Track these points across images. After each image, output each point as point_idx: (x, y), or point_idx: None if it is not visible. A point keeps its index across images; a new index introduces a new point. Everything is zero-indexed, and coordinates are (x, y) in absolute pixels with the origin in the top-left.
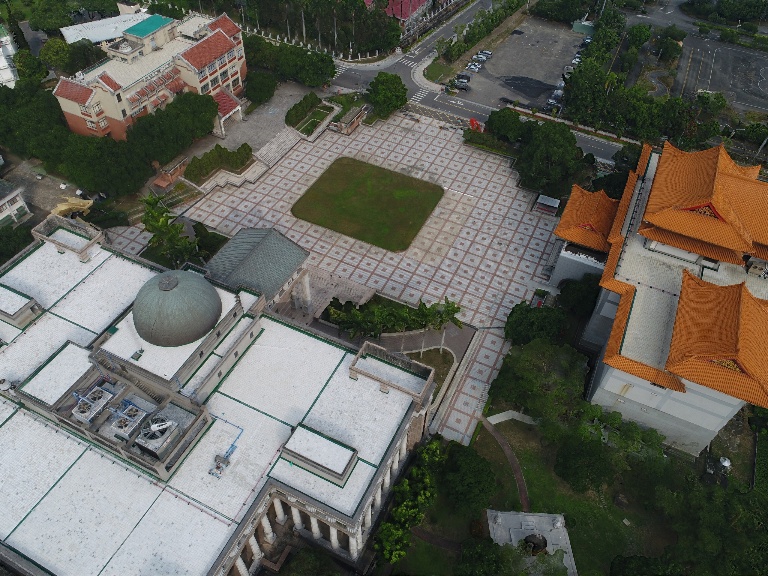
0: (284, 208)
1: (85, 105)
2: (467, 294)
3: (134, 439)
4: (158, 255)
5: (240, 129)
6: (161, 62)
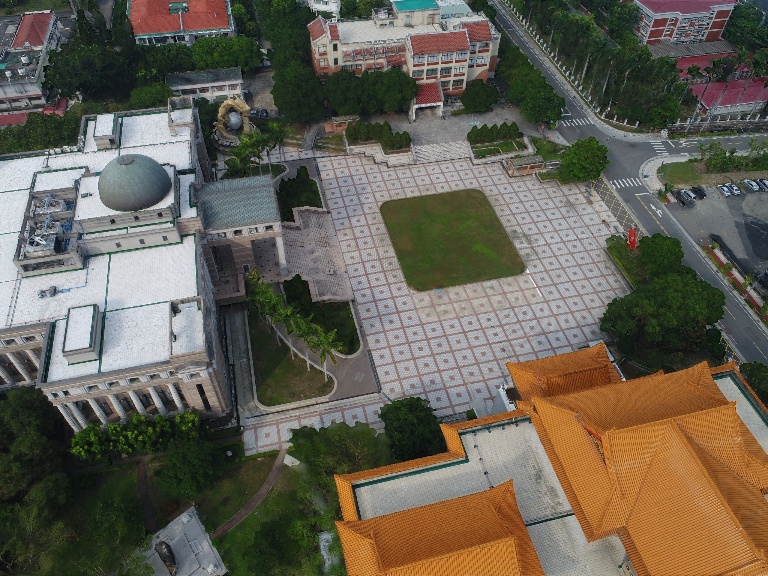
0: (382, 198)
1: (313, 42)
2: (413, 361)
3: None
4: (267, 173)
5: (431, 123)
6: (398, 36)
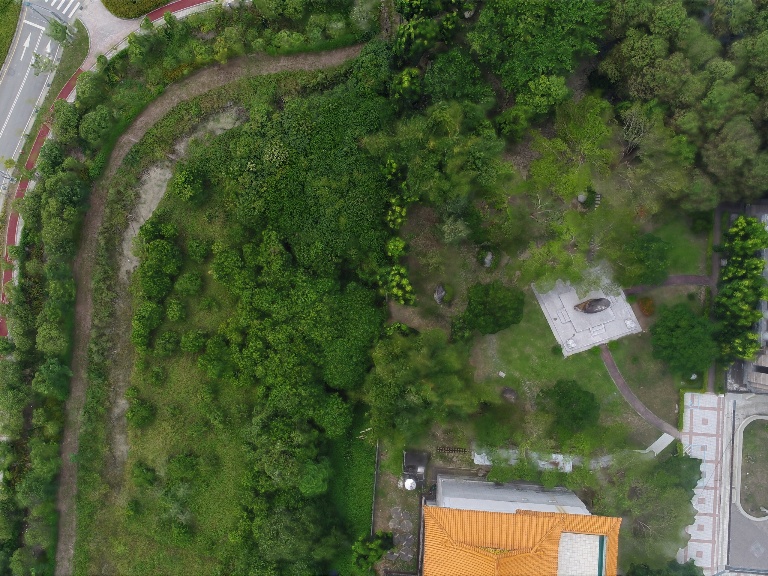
0: None
1: None
2: None
3: None
4: None
5: None
6: None
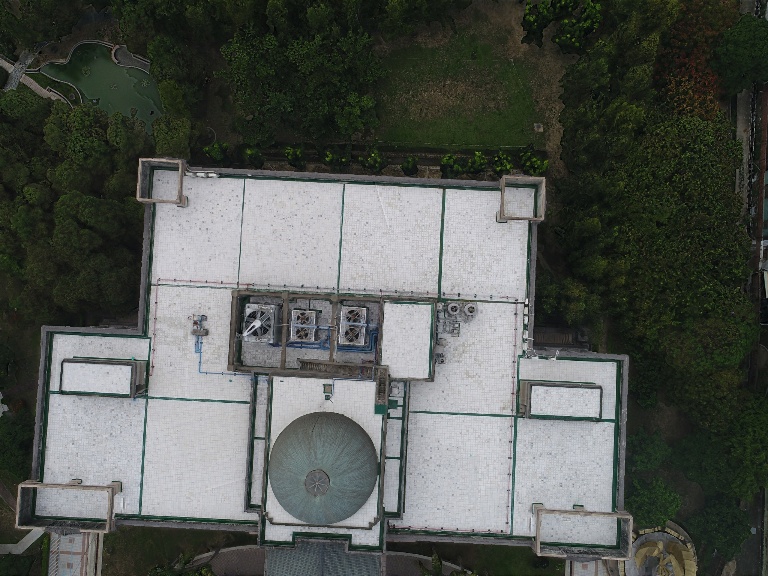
0: None
1: None
2: None
3: (284, 310)
4: None
5: None
6: None
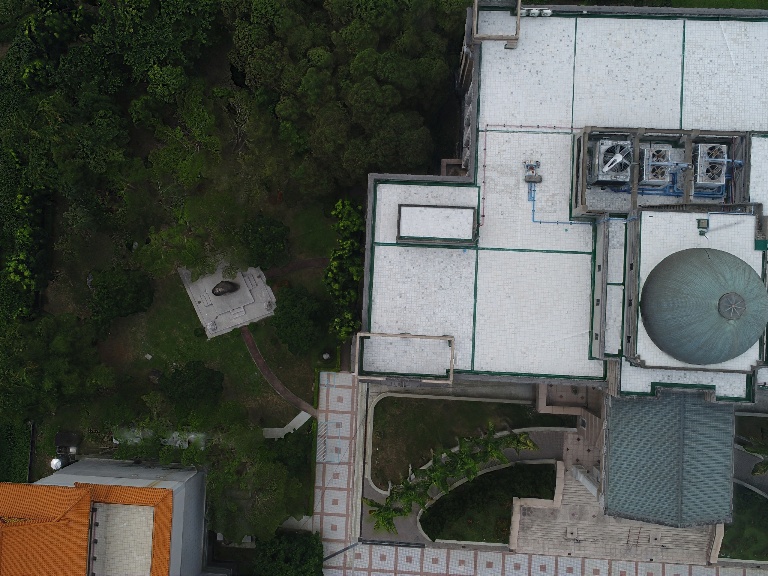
0: None
1: None
2: None
3: (635, 148)
4: None
5: None
6: None
